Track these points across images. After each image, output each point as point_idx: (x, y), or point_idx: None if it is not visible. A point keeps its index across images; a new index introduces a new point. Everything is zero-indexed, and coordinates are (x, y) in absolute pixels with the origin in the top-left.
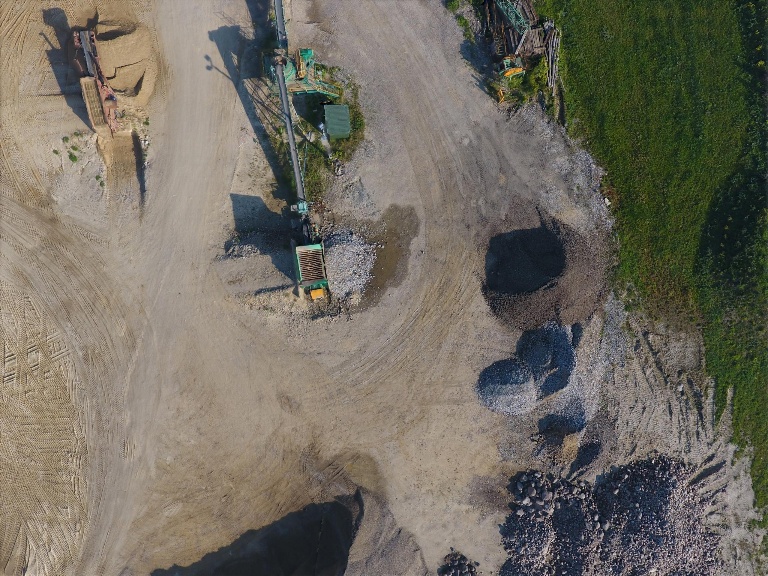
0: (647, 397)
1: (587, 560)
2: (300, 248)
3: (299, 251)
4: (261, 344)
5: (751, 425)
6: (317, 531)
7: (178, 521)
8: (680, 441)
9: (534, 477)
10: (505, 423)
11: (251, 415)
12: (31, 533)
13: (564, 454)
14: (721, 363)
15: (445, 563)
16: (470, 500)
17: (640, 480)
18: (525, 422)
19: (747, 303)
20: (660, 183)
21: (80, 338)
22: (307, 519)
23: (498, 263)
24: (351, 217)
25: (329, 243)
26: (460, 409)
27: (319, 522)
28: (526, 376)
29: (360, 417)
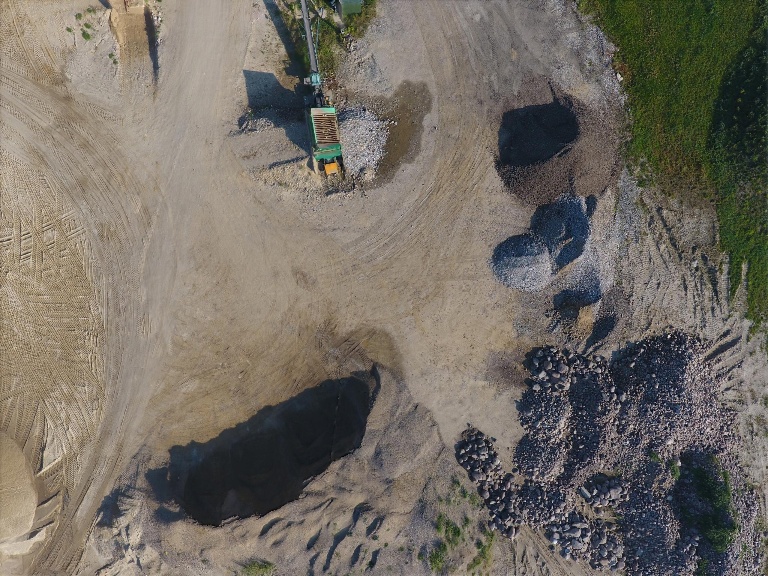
0: (662, 273)
1: (604, 431)
2: (315, 110)
3: (314, 113)
4: (276, 220)
5: (766, 301)
6: (334, 406)
7: (195, 397)
8: (695, 316)
9: (550, 352)
10: (520, 299)
11: (267, 291)
12: (49, 412)
13: (579, 328)
14: (735, 238)
15: (462, 439)
16: (486, 376)
17: (656, 354)
18: (540, 298)
19: (761, 174)
20: (672, 58)
21: (95, 216)
22: (324, 395)
23: (511, 138)
24: (364, 93)
25: (342, 118)
26: (475, 284)
27: (336, 397)
28: (541, 248)
29: (375, 293)
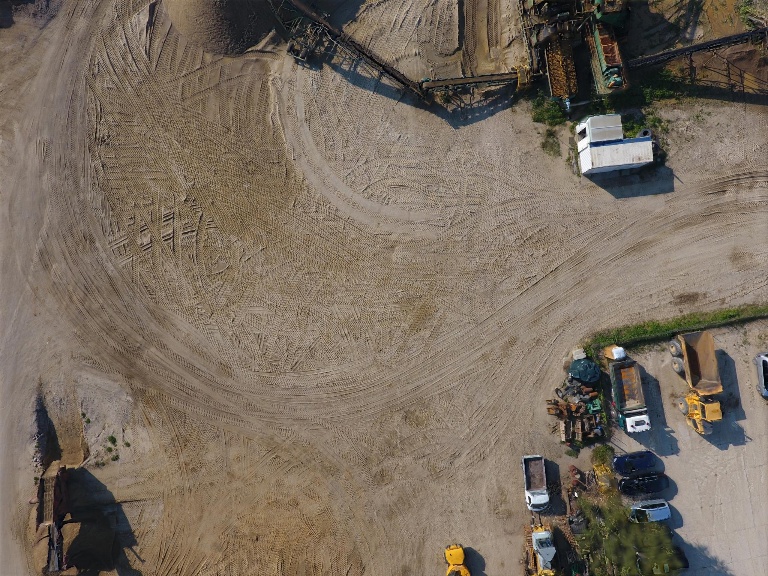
0: None
1: None
2: None
3: None
4: None
5: None
6: None
7: None
8: None
9: None
10: None
11: None
12: (145, 62)
13: None
14: None
15: None
16: None
17: None
18: None
19: None
20: None
21: (98, 260)
22: None
23: None
24: None
25: None
26: None
27: None
28: None
29: None
